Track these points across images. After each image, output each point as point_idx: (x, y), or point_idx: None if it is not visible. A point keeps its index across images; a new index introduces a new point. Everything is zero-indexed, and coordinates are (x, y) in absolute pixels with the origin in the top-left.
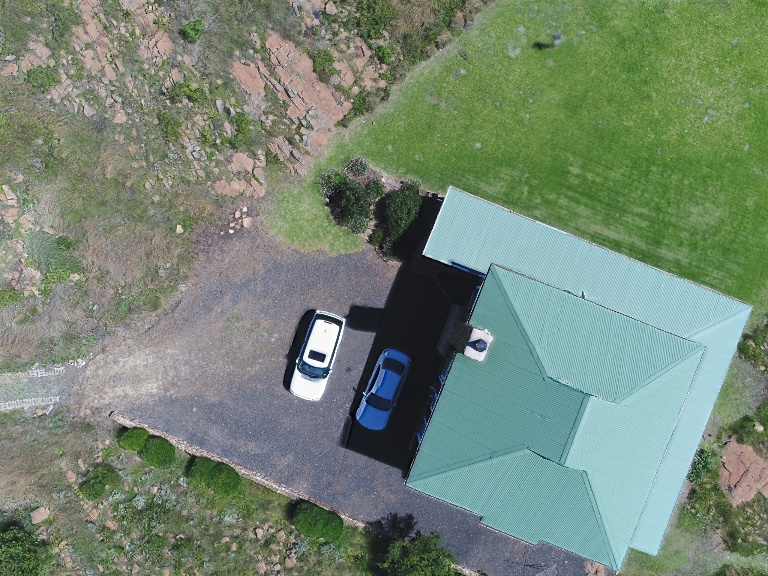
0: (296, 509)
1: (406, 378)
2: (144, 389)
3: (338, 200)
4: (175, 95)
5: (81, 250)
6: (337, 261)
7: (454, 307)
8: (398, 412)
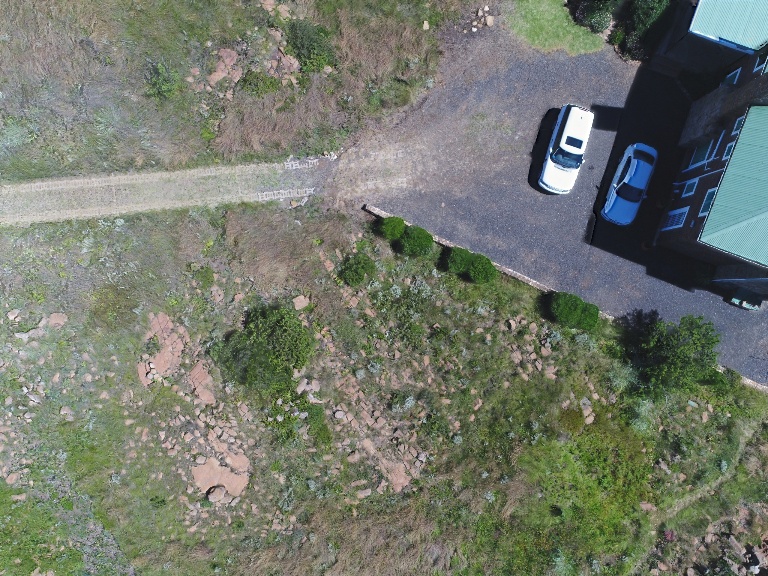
0: (553, 297)
1: (653, 171)
2: (395, 183)
3: (576, 1)
4: None
5: (335, 41)
6: (577, 61)
7: (705, 97)
8: (641, 209)
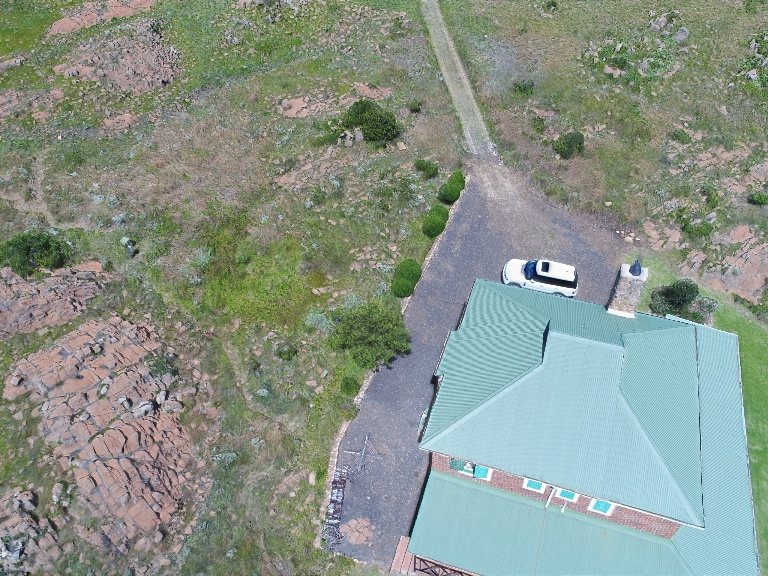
0: None
1: None
2: (489, 191)
3: None
4: (707, 188)
5: (577, 157)
6: None
7: None
8: None
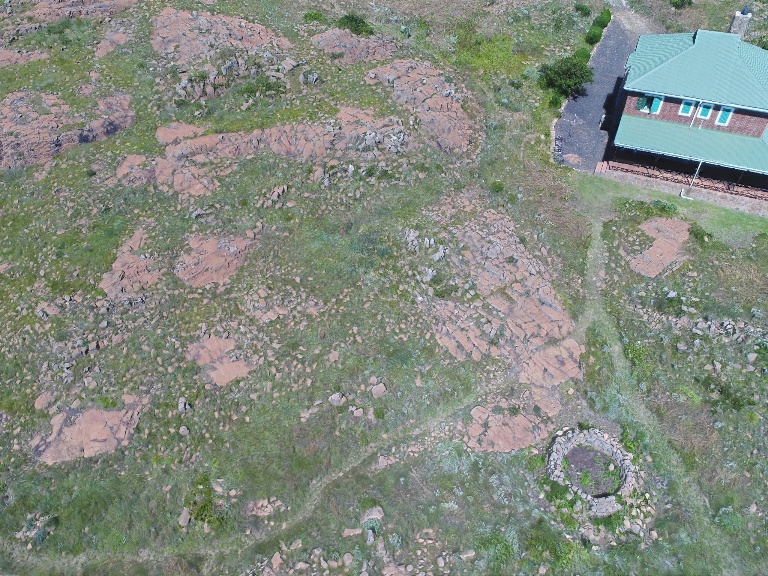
0: None
1: None
2: (627, 25)
3: None
4: None
5: (688, 8)
6: None
7: None
8: None
